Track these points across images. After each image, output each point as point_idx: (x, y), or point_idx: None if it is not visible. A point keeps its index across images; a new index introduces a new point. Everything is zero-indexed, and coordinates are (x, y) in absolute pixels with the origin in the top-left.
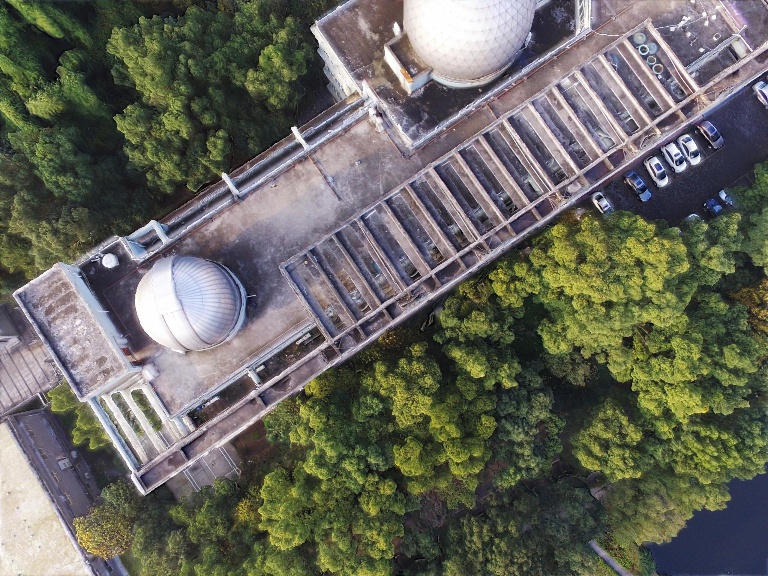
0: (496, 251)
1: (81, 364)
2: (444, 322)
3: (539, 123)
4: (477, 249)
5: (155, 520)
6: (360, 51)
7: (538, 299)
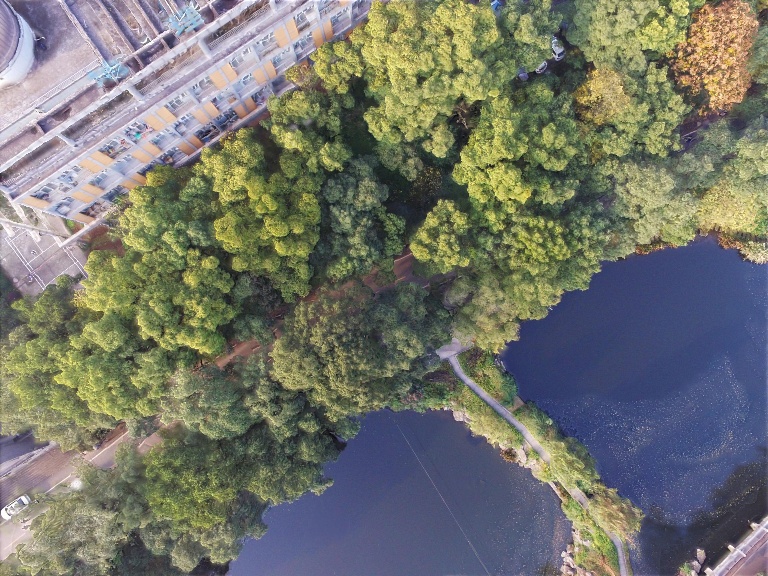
0: None
1: None
2: (269, 106)
3: None
4: None
5: (1, 318)
6: None
7: (368, 90)
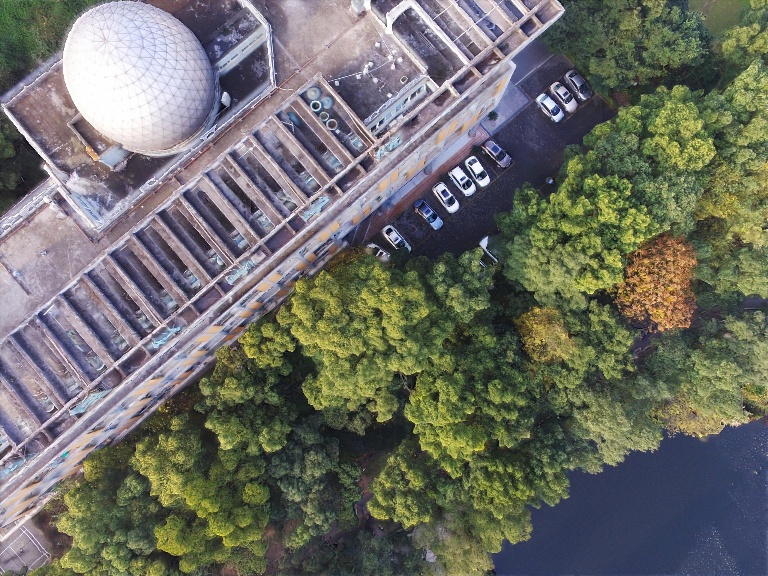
0: (179, 334)
1: None
2: (202, 391)
3: (217, 194)
4: (158, 335)
5: None
6: (57, 129)
7: (305, 353)
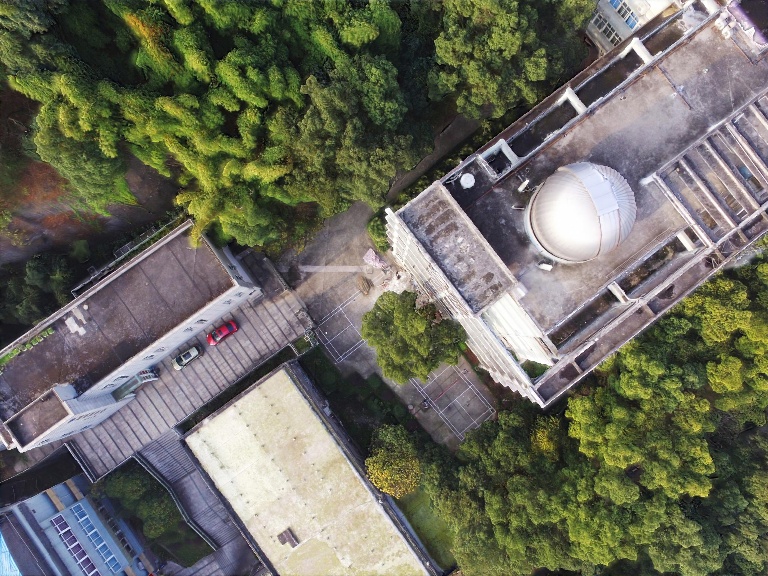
0: None
1: (467, 281)
2: None
3: None
4: None
5: (439, 457)
6: None
7: None
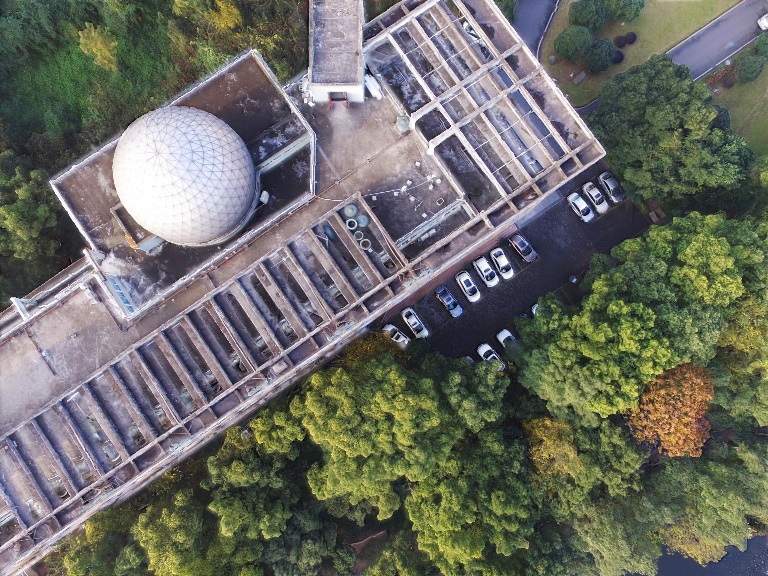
0: (195, 436)
1: None
2: (209, 469)
3: (246, 300)
4: (175, 435)
5: None
6: (99, 208)
7: None
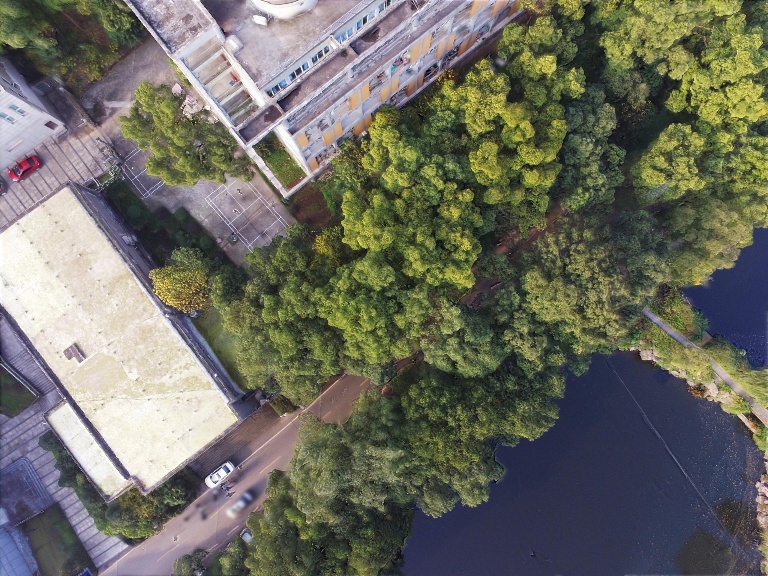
0: None
1: (167, 24)
2: (508, 36)
3: None
4: None
5: (229, 274)
6: None
7: (596, 17)
